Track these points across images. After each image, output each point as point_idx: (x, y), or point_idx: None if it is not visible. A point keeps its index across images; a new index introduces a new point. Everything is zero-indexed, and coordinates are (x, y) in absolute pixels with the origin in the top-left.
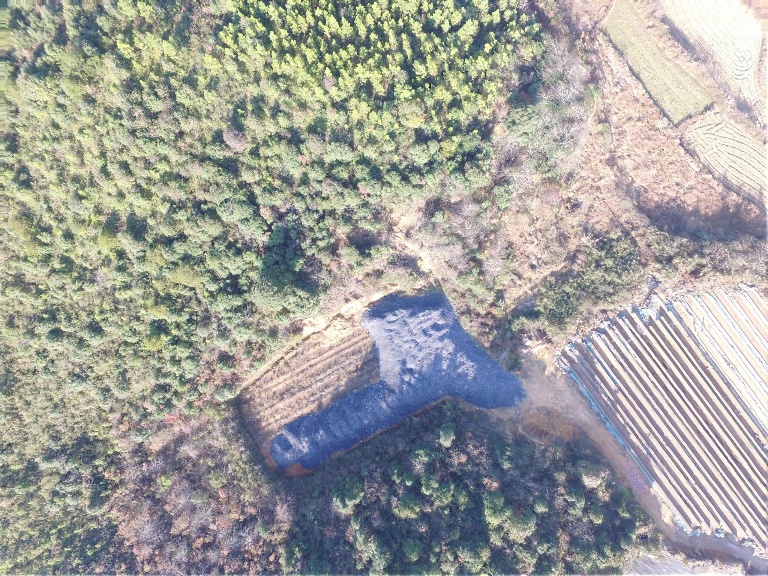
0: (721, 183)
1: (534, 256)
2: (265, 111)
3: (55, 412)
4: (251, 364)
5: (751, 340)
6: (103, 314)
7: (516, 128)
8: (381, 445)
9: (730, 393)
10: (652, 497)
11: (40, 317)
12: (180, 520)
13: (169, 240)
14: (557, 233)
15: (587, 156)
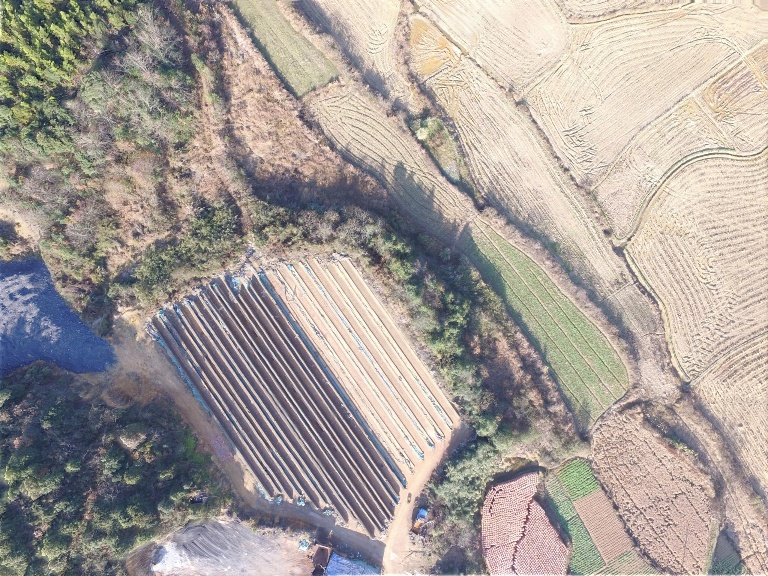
0: (339, 155)
1: (137, 224)
2: None
3: None
4: None
5: (342, 309)
6: None
7: (84, 94)
8: None
9: (315, 362)
10: (235, 464)
11: None
12: None
13: None
14: (160, 201)
15: (201, 126)
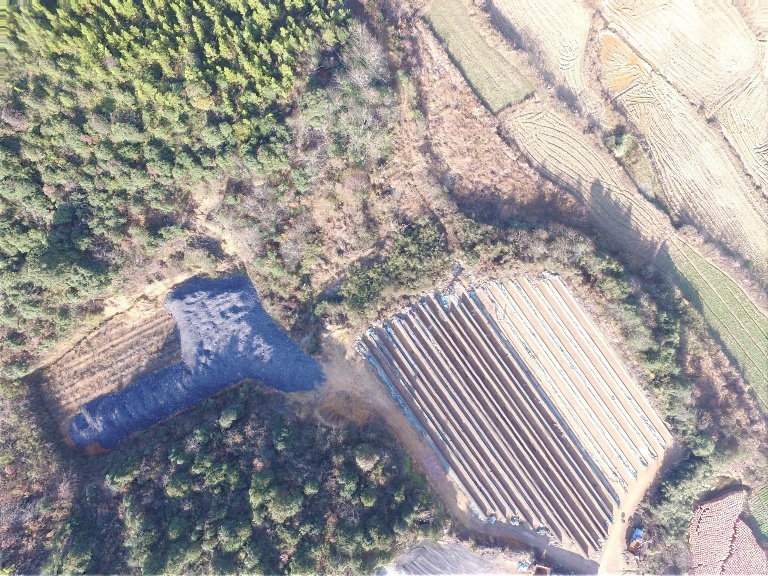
0: (537, 172)
1: (341, 241)
2: (47, 90)
3: None
4: (39, 342)
5: (553, 328)
6: None
7: (307, 112)
8: (175, 425)
9: (528, 381)
10: (448, 483)
11: None
12: None
13: None
14: (365, 219)
15: (401, 143)
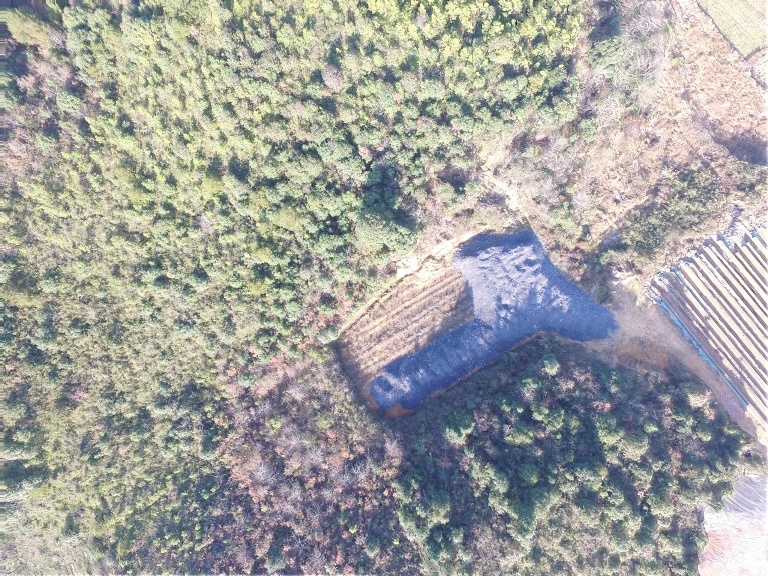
0: None
1: (618, 191)
2: (360, 50)
3: (164, 359)
4: (353, 304)
5: None
6: (207, 260)
7: (602, 60)
8: (481, 381)
9: None
10: (747, 420)
11: (145, 266)
12: (292, 461)
13: (271, 182)
14: (639, 167)
15: (662, 91)
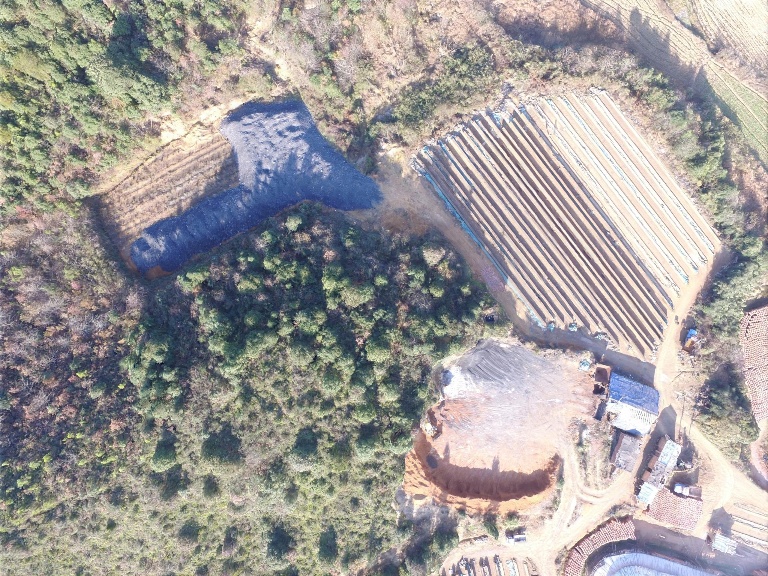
0: (578, 0)
1: (392, 66)
2: None
3: None
4: (101, 157)
5: (602, 141)
6: None
7: None
8: (237, 243)
9: (581, 191)
10: (507, 294)
11: None
12: (30, 308)
13: (11, 25)
14: (414, 43)
15: None
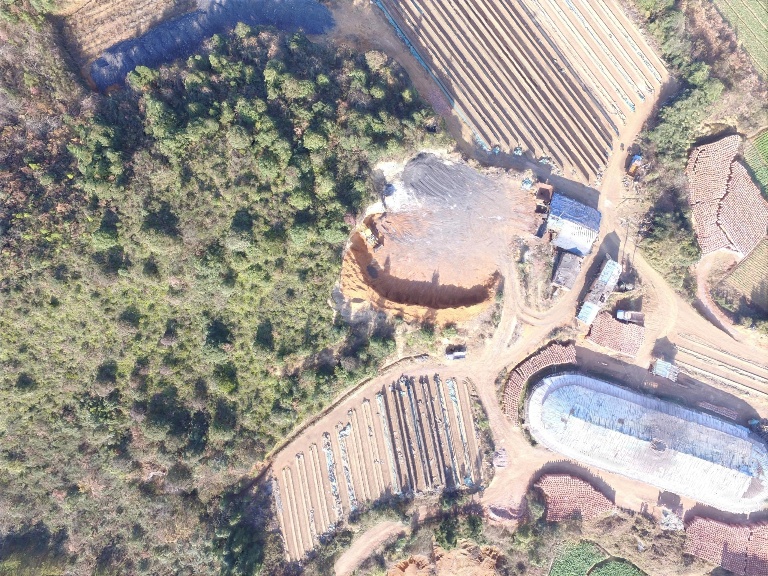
0: None
1: None
2: None
3: None
4: None
5: None
6: None
7: None
8: None
9: (529, 19)
10: (453, 117)
11: None
12: None
13: None
14: None
15: None
